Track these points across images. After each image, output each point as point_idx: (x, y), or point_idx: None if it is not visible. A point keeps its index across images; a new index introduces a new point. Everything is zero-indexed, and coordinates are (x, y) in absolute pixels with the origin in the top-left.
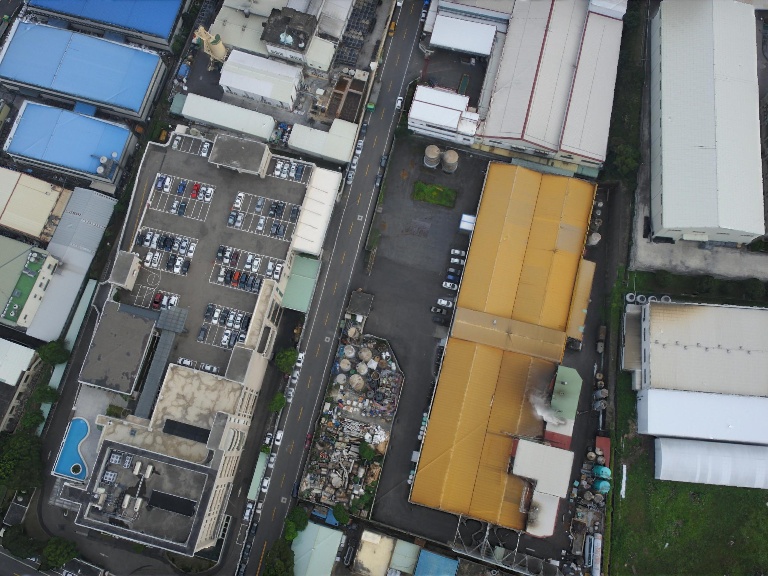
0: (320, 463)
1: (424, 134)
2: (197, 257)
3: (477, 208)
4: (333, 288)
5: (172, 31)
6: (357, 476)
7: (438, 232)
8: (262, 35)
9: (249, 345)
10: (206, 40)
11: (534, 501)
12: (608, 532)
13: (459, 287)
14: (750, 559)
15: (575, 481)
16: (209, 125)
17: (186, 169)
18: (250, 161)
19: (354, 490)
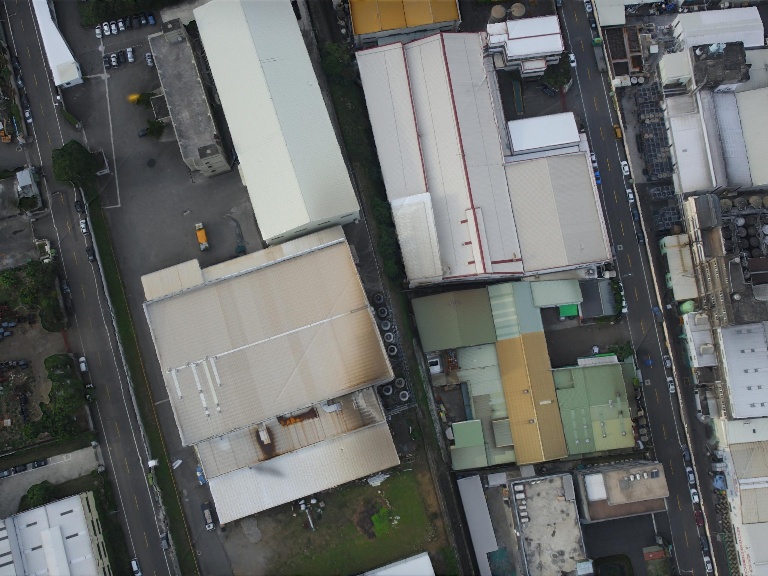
0: None
1: None
2: None
3: None
4: None
5: None
6: None
7: None
8: None
9: None
10: None
11: None
12: None
13: None
14: None
15: None
16: None
17: None
18: None
19: None
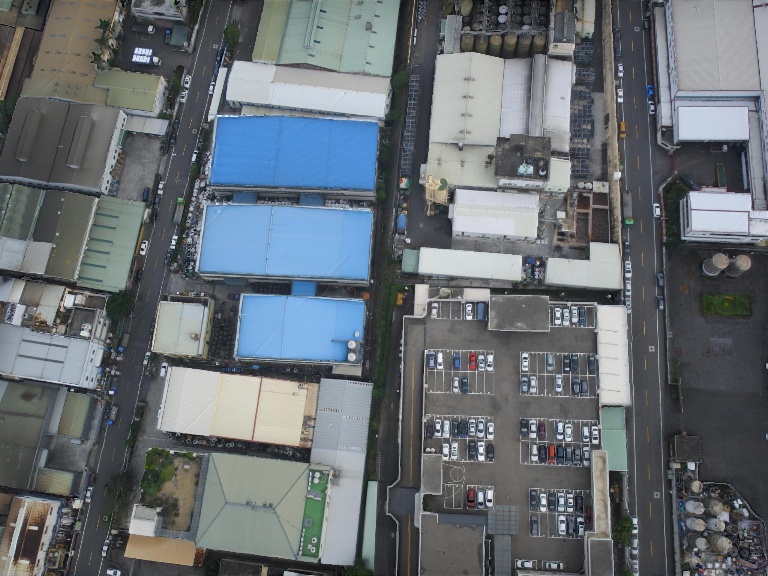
0: None
1: (697, 241)
2: (498, 438)
3: None
4: (646, 435)
5: (374, 180)
6: None
7: (743, 347)
8: (495, 170)
9: (599, 532)
10: (434, 188)
11: None
12: None
13: None
14: None
15: None
16: (449, 277)
17: (454, 338)
18: (536, 319)
19: None
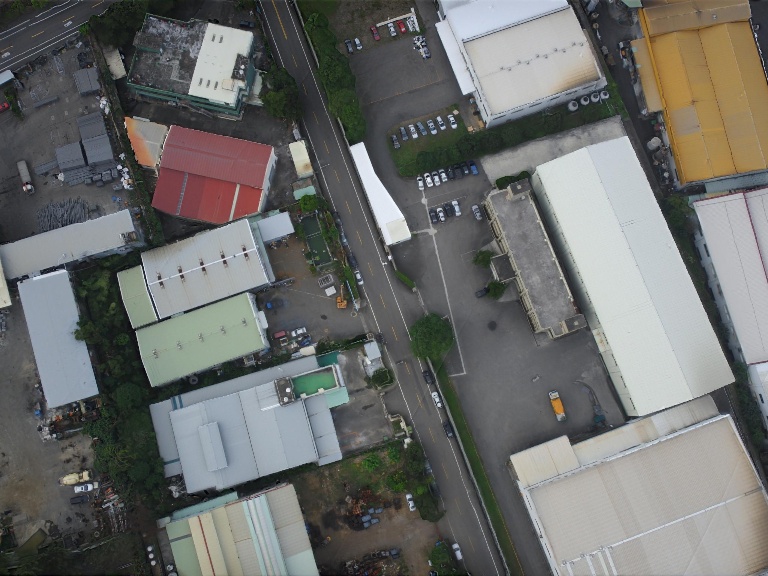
0: None
1: None
2: None
3: None
4: None
5: None
6: None
7: None
8: None
9: None
10: None
11: None
12: None
13: None
14: None
15: None
16: None
17: None
18: None
19: None
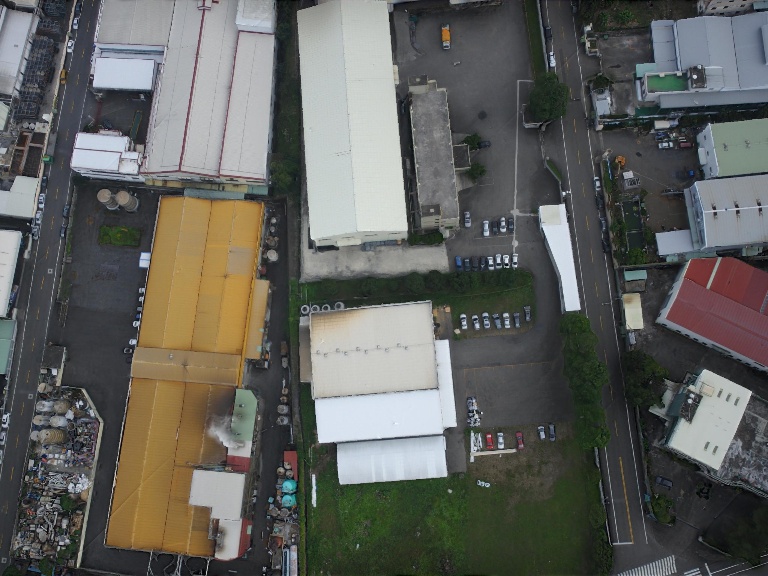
0: (27, 520)
1: (101, 178)
2: None
3: (151, 245)
4: (31, 345)
5: None
6: (61, 527)
7: (126, 273)
8: None
9: None
10: None
11: (220, 526)
12: (302, 543)
13: (138, 327)
14: (436, 547)
15: (269, 498)
16: None
17: None
18: None
19: (59, 542)
